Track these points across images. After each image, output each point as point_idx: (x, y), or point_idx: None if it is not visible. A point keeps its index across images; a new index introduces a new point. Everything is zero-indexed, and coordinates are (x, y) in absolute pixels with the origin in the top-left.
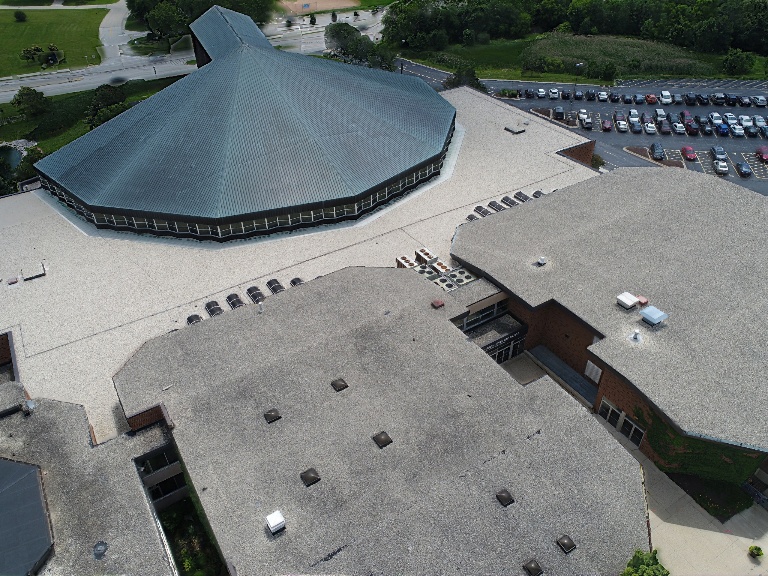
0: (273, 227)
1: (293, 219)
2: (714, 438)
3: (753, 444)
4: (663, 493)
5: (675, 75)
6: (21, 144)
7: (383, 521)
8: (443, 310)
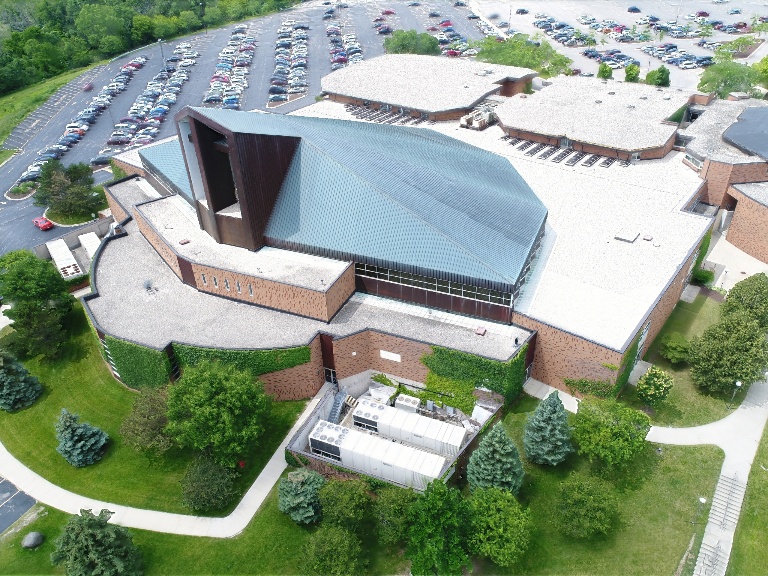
0: None
1: None
2: None
3: None
4: None
5: (3, 129)
6: None
7: None
8: None
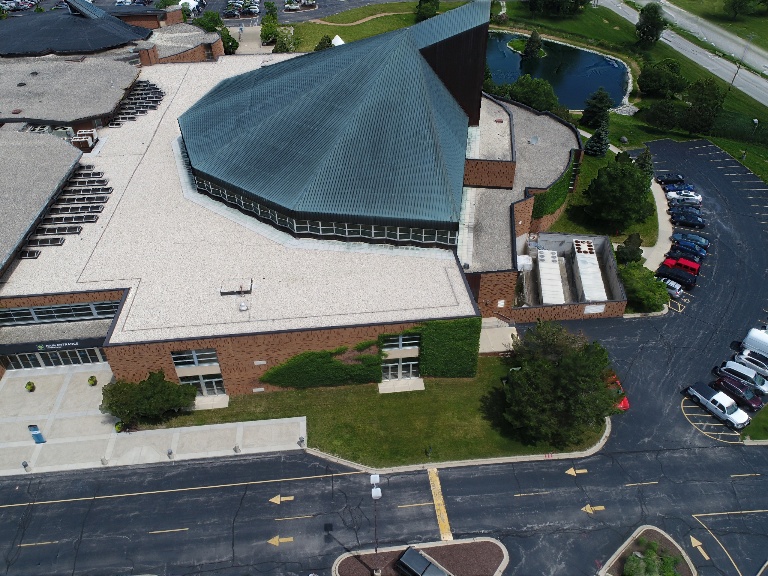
0: None
1: None
2: None
3: None
4: None
5: None
6: (626, 109)
7: None
8: None
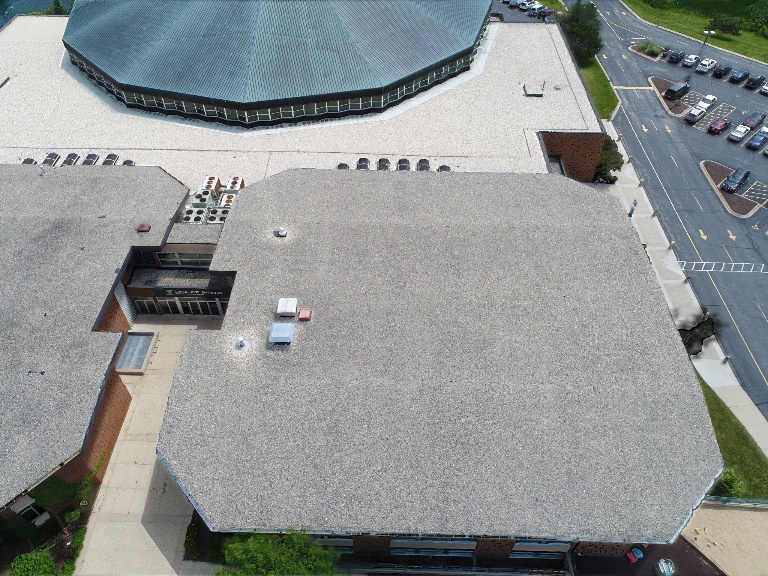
0: (171, 109)
1: (188, 107)
2: (173, 473)
3: (198, 502)
4: (174, 501)
5: None
6: None
7: None
8: (141, 235)
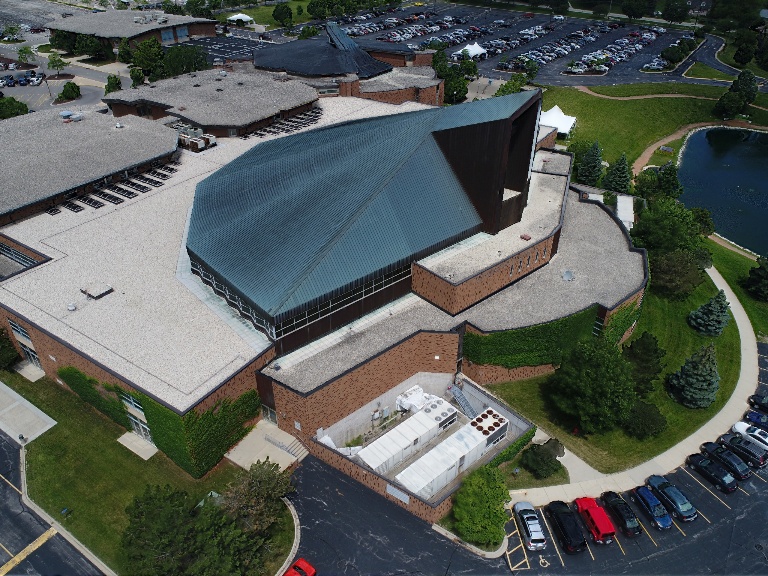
0: None
1: None
2: None
3: None
4: None
5: None
6: None
7: (192, 79)
8: None
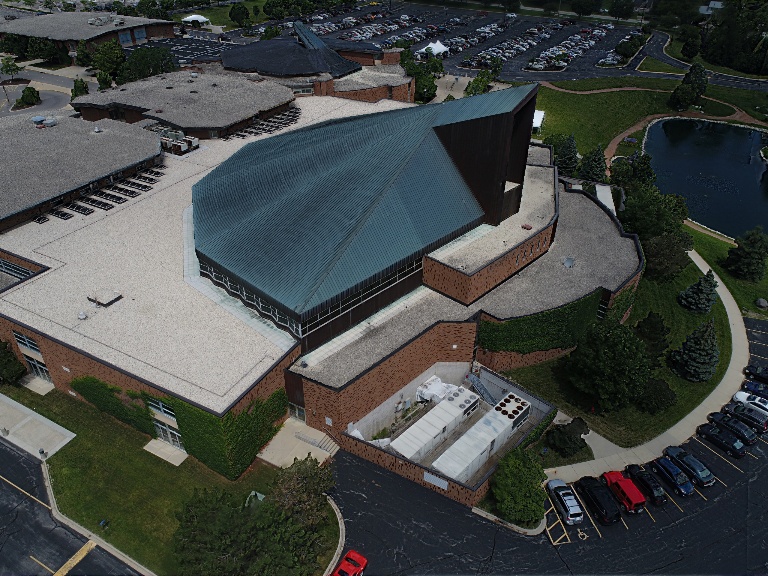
0: None
1: None
2: None
3: None
4: None
5: None
6: None
7: None
8: None
